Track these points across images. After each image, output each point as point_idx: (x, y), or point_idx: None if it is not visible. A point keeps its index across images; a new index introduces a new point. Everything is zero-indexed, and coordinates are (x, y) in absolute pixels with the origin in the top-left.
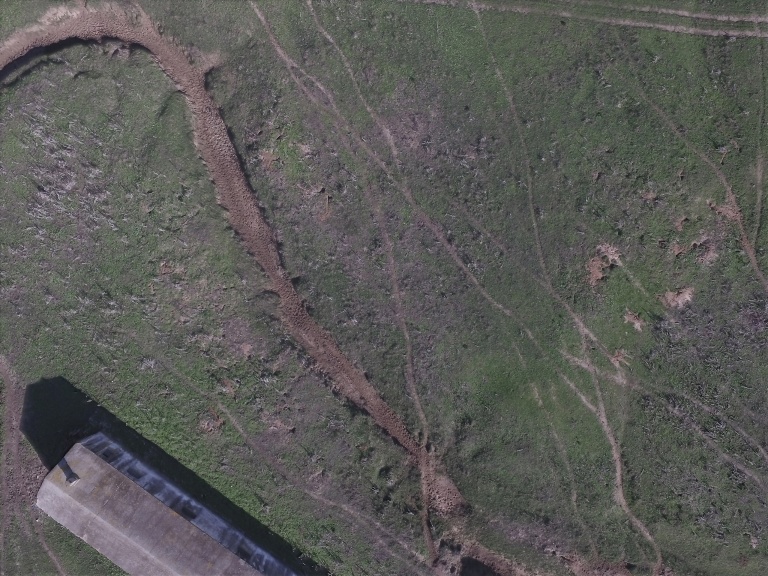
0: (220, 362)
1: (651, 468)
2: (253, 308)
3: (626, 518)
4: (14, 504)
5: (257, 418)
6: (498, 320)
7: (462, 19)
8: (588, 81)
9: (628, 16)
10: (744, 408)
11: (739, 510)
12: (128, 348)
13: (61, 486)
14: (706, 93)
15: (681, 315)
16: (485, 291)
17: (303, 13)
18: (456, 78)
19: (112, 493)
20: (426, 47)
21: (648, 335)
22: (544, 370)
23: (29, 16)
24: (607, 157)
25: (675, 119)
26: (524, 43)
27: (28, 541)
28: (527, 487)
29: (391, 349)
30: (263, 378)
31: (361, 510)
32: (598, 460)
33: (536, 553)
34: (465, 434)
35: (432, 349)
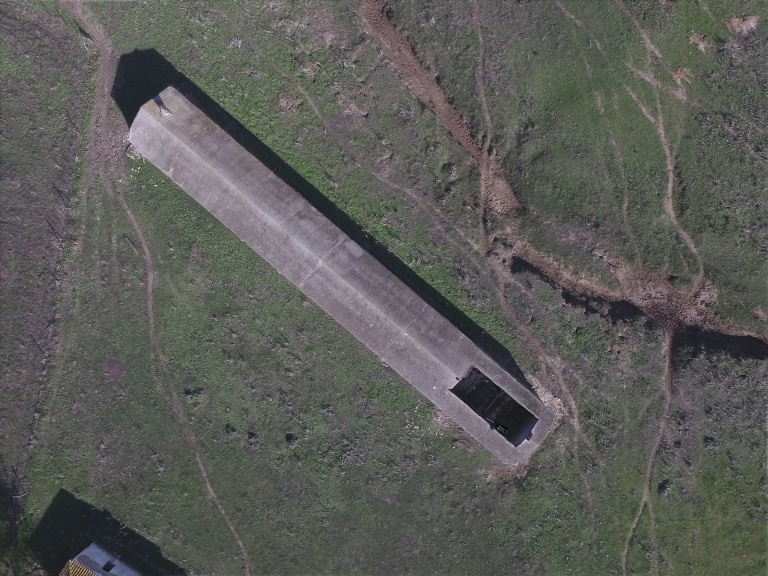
0: (303, 47)
1: (703, 179)
2: (338, 3)
3: (673, 230)
4: (100, 164)
5: (334, 101)
6: (569, 29)
7: None
8: None
9: None
10: None
11: None
12: (218, 27)
13: (155, 116)
14: None
15: (744, 41)
16: (559, 1)
17: None
18: None
19: (200, 131)
20: None
21: (711, 57)
22: (609, 80)
23: None
24: None
25: None
26: None
27: (110, 198)
28: (582, 191)
29: (464, 51)
30: (343, 64)
31: (423, 196)
32: (652, 169)
33: (584, 256)
34: (527, 137)
35: (504, 53)
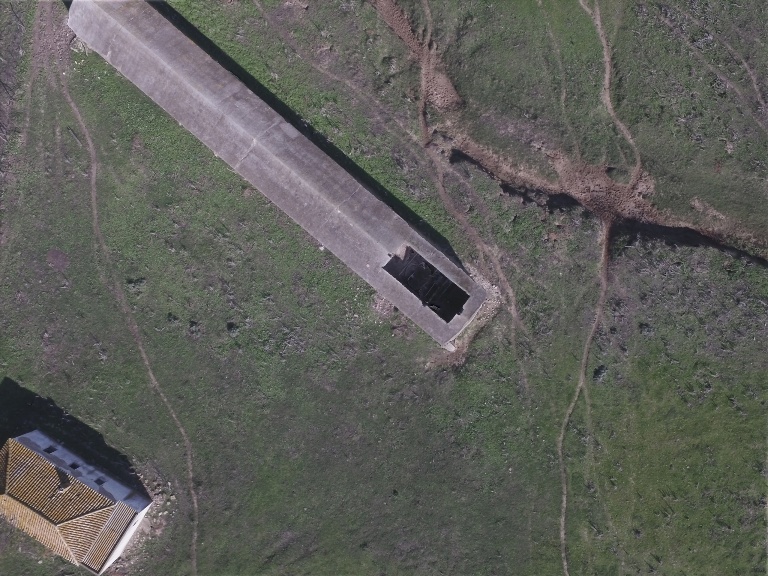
0: None
1: (638, 69)
2: None
3: (610, 121)
4: (44, 57)
5: None
6: None
7: None
8: None
9: None
10: (732, 24)
11: (718, 117)
12: None
13: None
14: None
15: None
16: None
17: None
18: None
19: (137, 14)
20: None
21: None
22: None
23: None
24: None
25: None
26: None
27: (54, 91)
28: (520, 82)
29: None
30: None
31: (363, 87)
32: (589, 60)
33: (522, 148)
34: (466, 30)
35: None
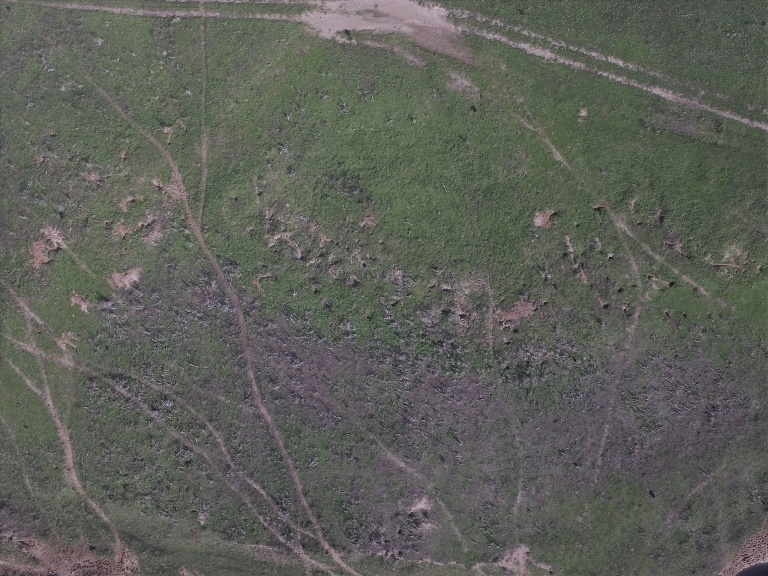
0: None
1: (95, 449)
2: None
3: (81, 500)
4: None
5: None
6: None
7: None
8: (33, 66)
9: None
10: (192, 386)
11: (187, 487)
12: None
13: None
14: (153, 74)
15: (129, 296)
16: None
17: None
18: None
19: None
20: None
21: (95, 317)
22: None
23: None
24: (51, 141)
25: (119, 101)
26: None
27: None
28: None
29: None
30: None
31: None
32: (45, 443)
33: None
34: None
35: None
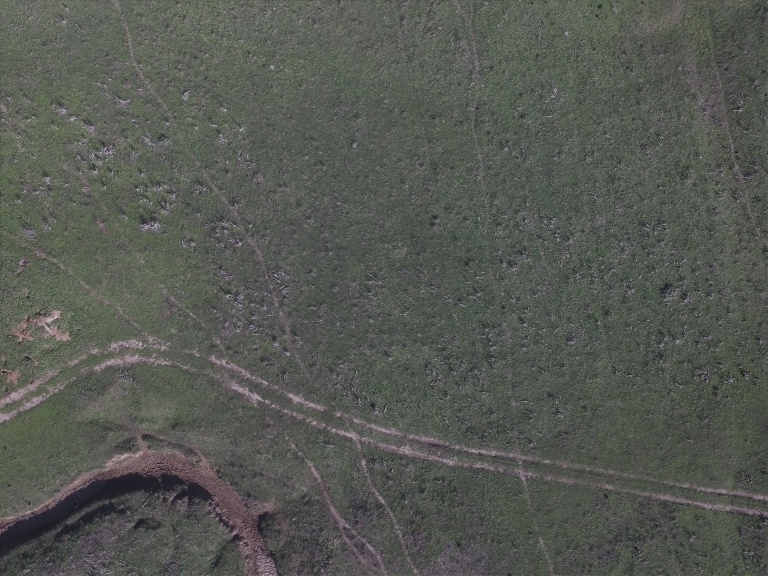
0: None
1: None
2: None
3: None
4: None
5: None
6: None
7: (509, 486)
8: (627, 555)
9: (668, 491)
10: None
11: None
12: None
13: None
14: (739, 572)
15: None
16: None
17: (357, 474)
18: (500, 545)
19: None
20: (473, 513)
21: None
22: None
23: (95, 463)
24: None
25: None
26: (567, 514)
27: None
28: None
29: None
30: None
31: None
32: None
33: None
34: None
35: None
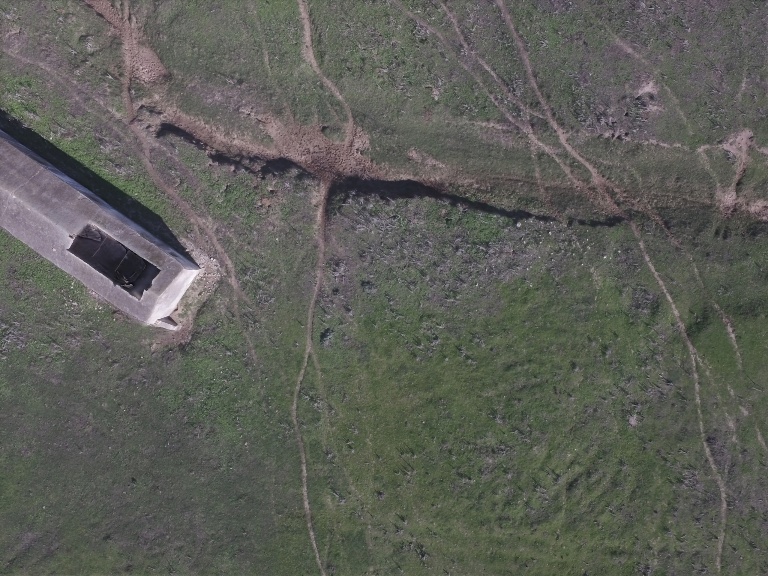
0: None
1: (336, 23)
2: None
3: (317, 79)
4: None
5: None
6: None
7: None
8: None
9: None
10: None
11: (422, 65)
12: None
13: None
14: None
15: None
16: None
17: None
18: None
19: None
20: None
21: None
22: None
23: None
24: None
25: None
26: None
27: None
28: (220, 48)
29: None
30: None
31: (58, 69)
32: (286, 19)
33: (232, 115)
34: (162, 0)
35: None
